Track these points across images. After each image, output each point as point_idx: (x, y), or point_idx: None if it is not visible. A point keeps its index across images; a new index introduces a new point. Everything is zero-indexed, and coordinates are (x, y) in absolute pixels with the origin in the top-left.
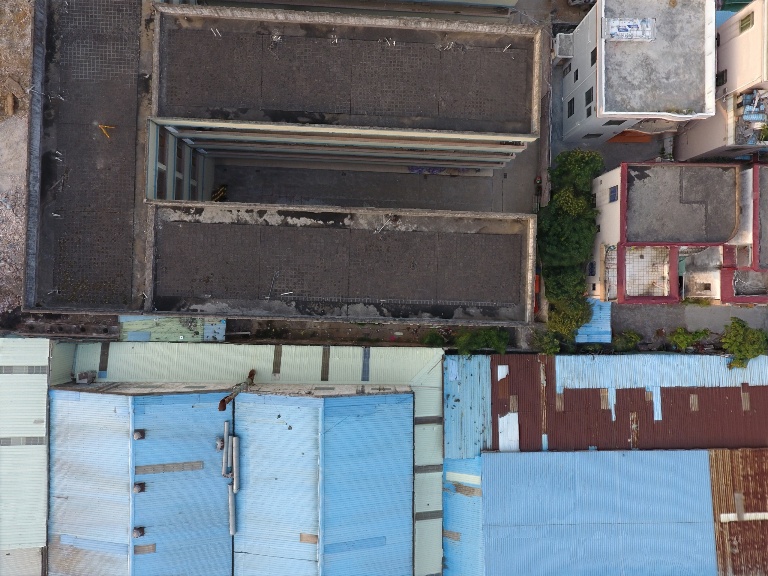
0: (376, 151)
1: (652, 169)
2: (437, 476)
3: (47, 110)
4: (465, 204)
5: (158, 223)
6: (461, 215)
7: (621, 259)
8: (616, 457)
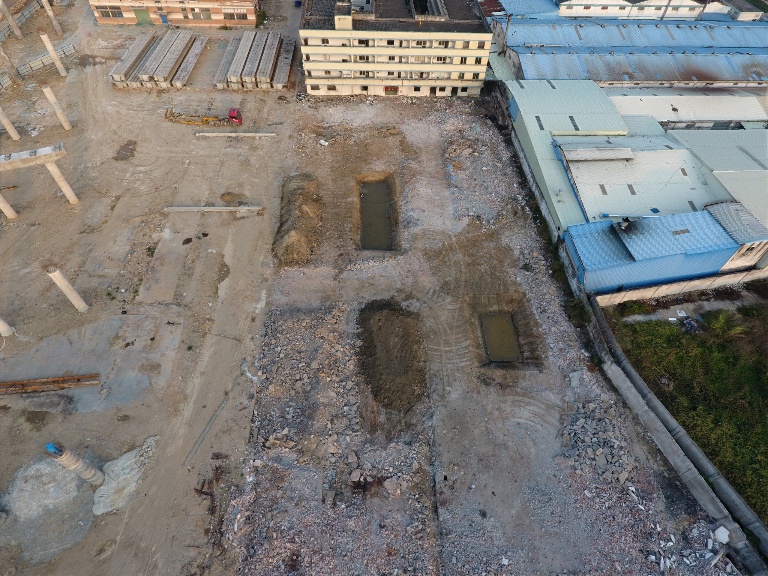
0: None
1: None
2: None
3: None
4: None
5: None
6: None
7: None
8: None
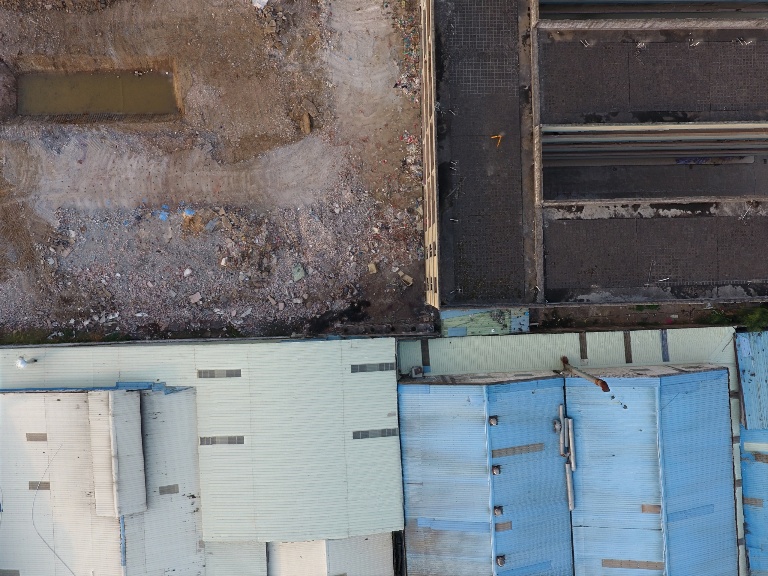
0: (692, 144)
1: None
2: (736, 447)
3: (440, 125)
4: (730, 190)
5: (544, 222)
6: None
7: None
8: None
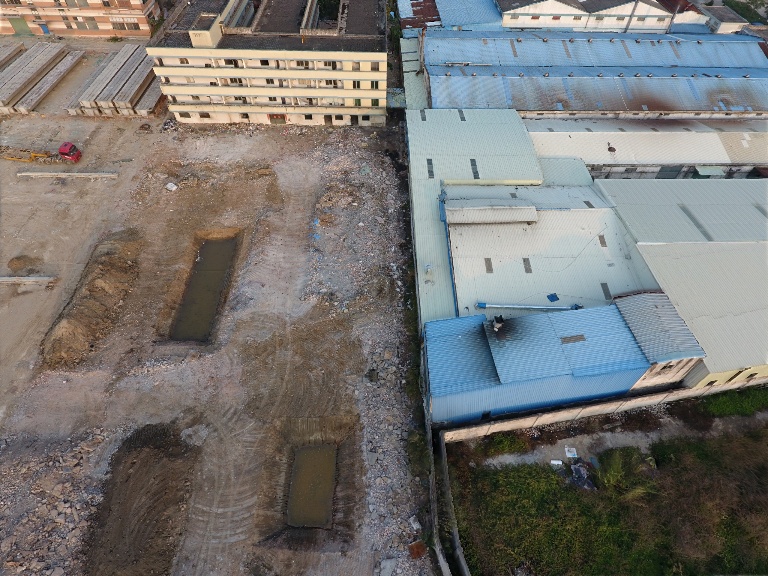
0: None
1: None
2: None
3: None
4: None
5: None
6: None
7: None
8: (439, 4)
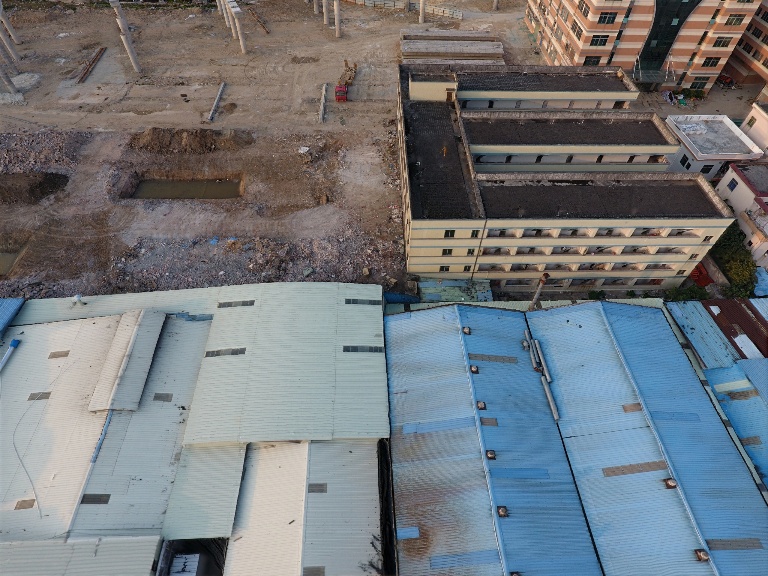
0: None
1: (749, 167)
2: (707, 389)
3: (409, 149)
4: None
5: (480, 187)
6: (656, 178)
7: (762, 204)
8: None
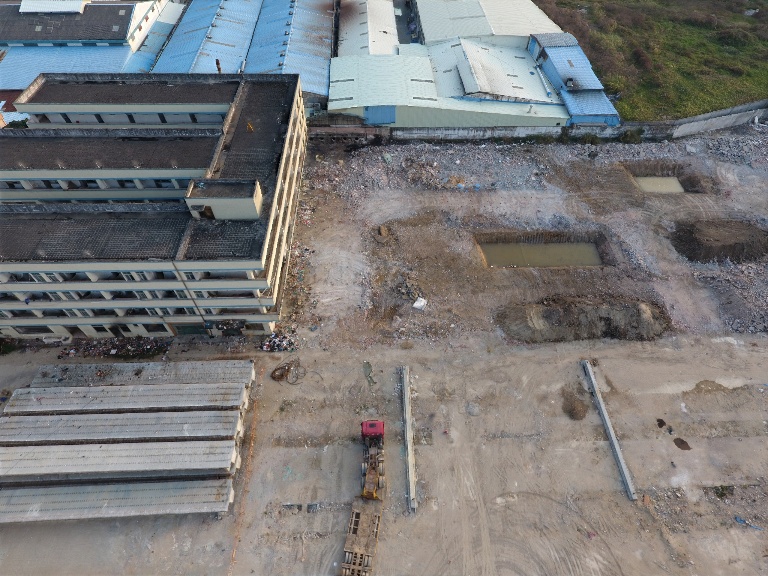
0: None
1: None
2: None
3: None
4: None
5: None
6: (59, 109)
7: None
8: None
